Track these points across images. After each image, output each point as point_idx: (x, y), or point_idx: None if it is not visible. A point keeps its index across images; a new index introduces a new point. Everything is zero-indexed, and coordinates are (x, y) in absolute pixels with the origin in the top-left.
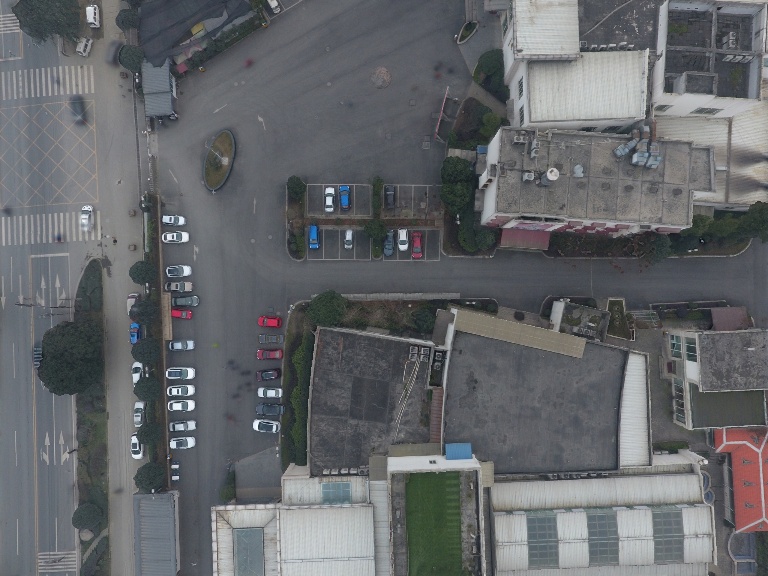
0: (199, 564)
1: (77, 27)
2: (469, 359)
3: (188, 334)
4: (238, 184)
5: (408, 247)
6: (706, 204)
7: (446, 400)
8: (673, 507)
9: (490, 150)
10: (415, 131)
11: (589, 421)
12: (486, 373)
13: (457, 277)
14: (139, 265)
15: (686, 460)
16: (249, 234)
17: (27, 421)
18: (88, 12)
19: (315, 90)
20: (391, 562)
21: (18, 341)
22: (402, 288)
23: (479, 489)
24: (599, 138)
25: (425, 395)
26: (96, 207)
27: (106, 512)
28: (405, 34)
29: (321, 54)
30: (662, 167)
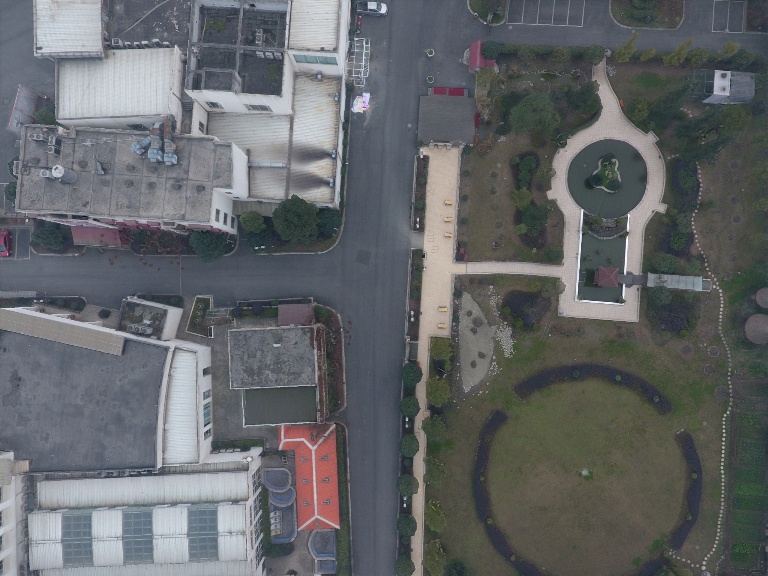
0: None
1: None
2: (13, 357)
3: None
4: None
5: None
6: (271, 201)
7: None
8: (211, 505)
9: None
10: None
11: (131, 419)
12: (30, 371)
13: (47, 275)
14: None
15: (241, 457)
16: None
17: None
18: None
19: None
20: None
21: None
22: None
23: None
24: (124, 135)
25: None
26: None
27: None
28: (0, 33)
29: None
30: (187, 164)
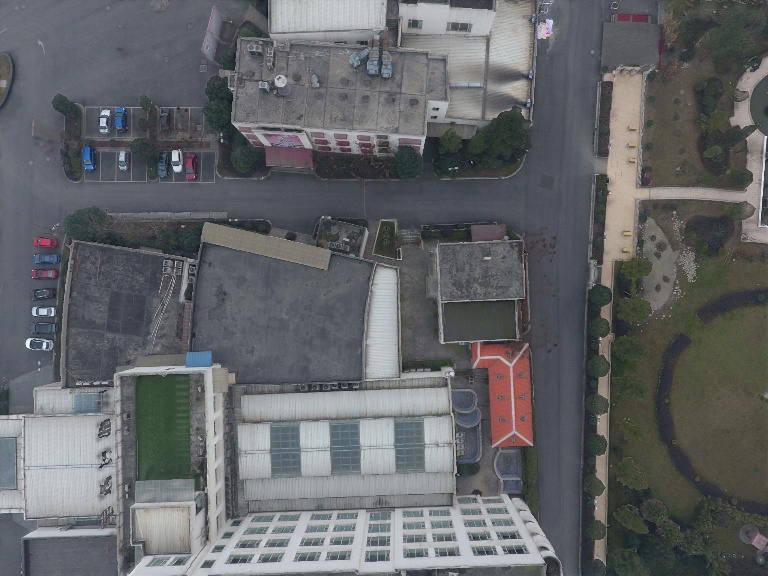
0: None
1: None
2: (218, 271)
3: None
4: (17, 107)
5: (183, 169)
6: (466, 122)
7: (192, 311)
8: (416, 417)
9: None
10: (192, 54)
11: (336, 333)
12: (235, 285)
13: (232, 199)
14: None
15: (439, 374)
16: (27, 156)
17: None
18: None
19: (94, 14)
20: (116, 463)
21: None
22: (177, 209)
23: None
24: (337, 49)
25: (181, 309)
26: None
27: None
28: None
29: None
30: (400, 78)
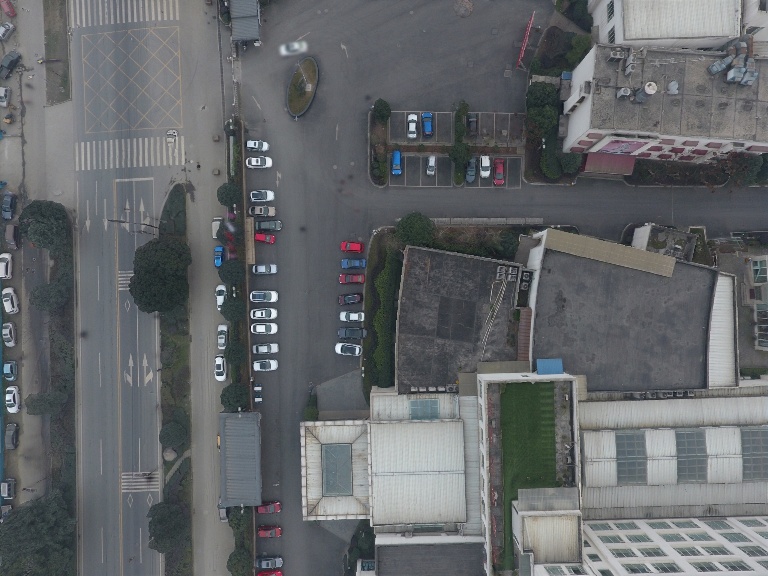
0: (280, 486)
1: None
2: (558, 278)
3: (270, 259)
4: (321, 111)
5: (490, 174)
6: None
7: (536, 317)
8: (761, 426)
9: (577, 74)
10: (497, 59)
11: (677, 340)
12: (575, 292)
13: (538, 204)
14: (227, 185)
15: None
16: (331, 160)
17: (111, 343)
18: None
19: (397, 18)
20: (487, 470)
21: (103, 264)
22: (483, 215)
23: (574, 400)
24: (693, 56)
25: (511, 315)
26: (180, 132)
27: (189, 433)
28: None
29: None
30: (756, 85)
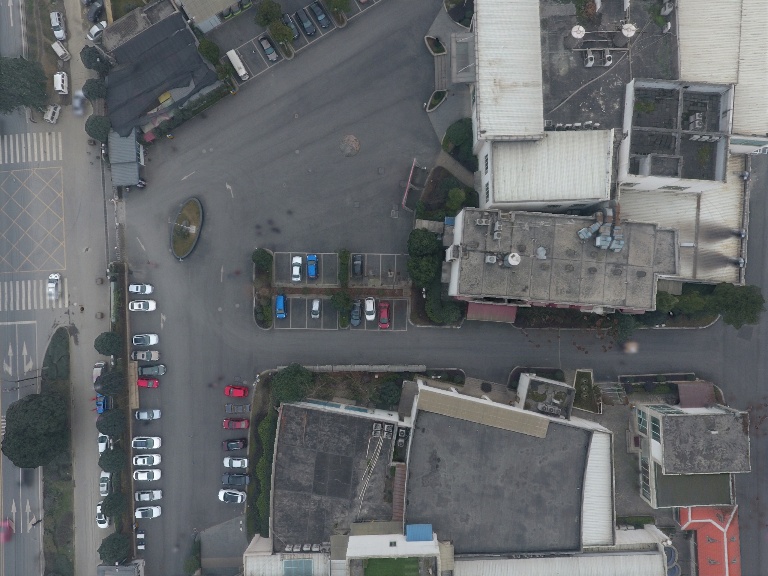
0: None
1: (43, 98)
2: (432, 437)
3: (155, 402)
4: (205, 252)
5: (375, 317)
6: (674, 279)
7: (408, 479)
8: None
9: (456, 224)
10: (383, 200)
11: (552, 501)
12: (449, 452)
13: (424, 347)
14: (104, 337)
15: (651, 539)
16: (216, 302)
17: None
18: (56, 80)
19: (283, 157)
20: None
21: None
22: (369, 358)
23: (438, 575)
24: (563, 219)
25: (389, 471)
26: (63, 274)
27: None
28: (374, 101)
29: (289, 121)
30: (626, 249)
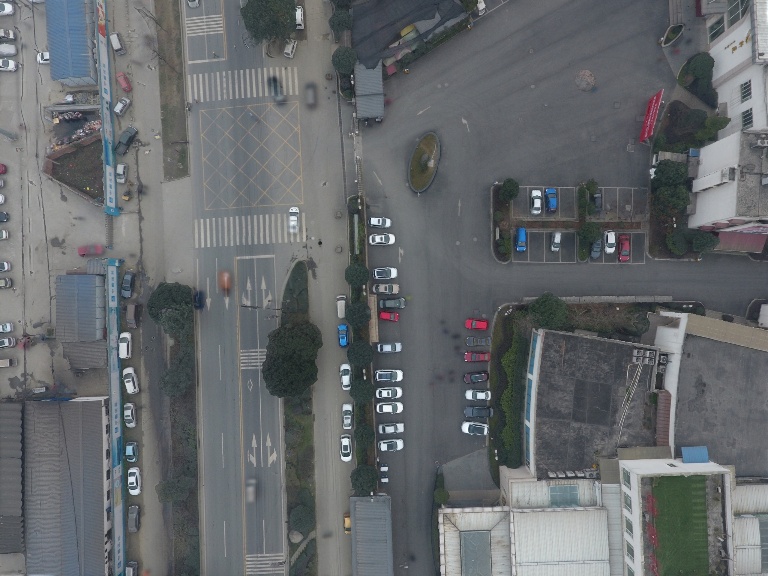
0: None
1: None
2: (697, 362)
3: (394, 336)
4: (443, 186)
5: (614, 250)
6: None
7: (677, 403)
8: None
9: (708, 153)
10: (620, 134)
11: None
12: (715, 376)
13: (663, 280)
14: (357, 267)
15: None
16: (454, 236)
17: (234, 423)
18: (296, 13)
19: (519, 92)
20: (642, 565)
21: (224, 343)
22: (608, 291)
23: (727, 493)
24: None
25: (647, 398)
26: (301, 209)
27: (314, 514)
28: (609, 37)
29: (525, 56)
30: None
